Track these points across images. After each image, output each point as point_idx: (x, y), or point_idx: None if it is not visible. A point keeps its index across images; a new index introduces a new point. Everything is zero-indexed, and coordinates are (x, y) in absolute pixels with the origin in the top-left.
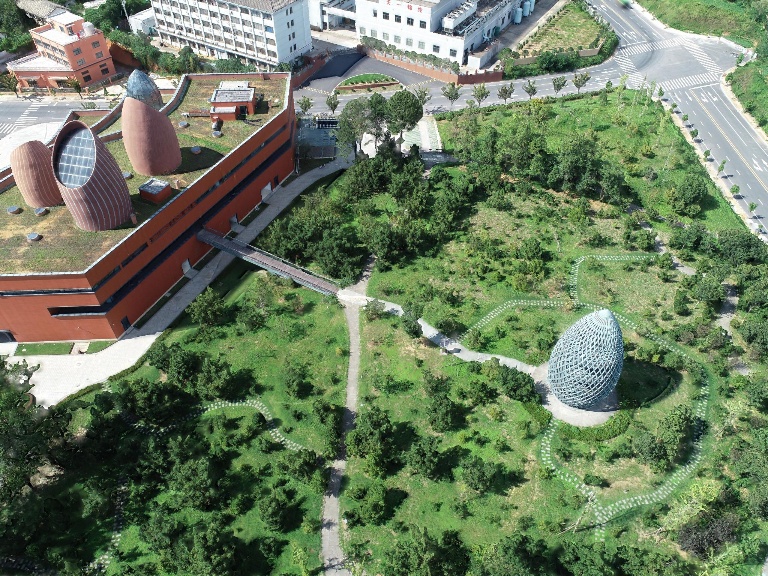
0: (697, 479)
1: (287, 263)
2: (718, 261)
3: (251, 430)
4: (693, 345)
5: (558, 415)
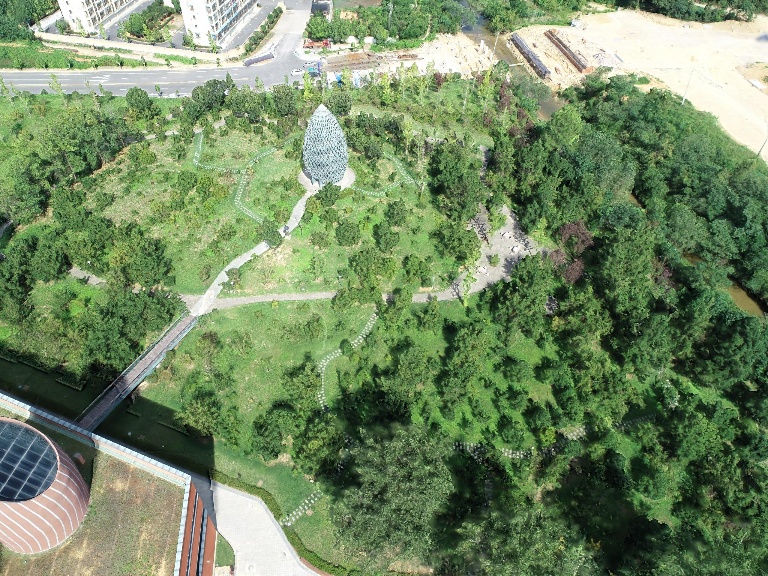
0: None
1: (140, 359)
2: (215, 109)
3: None
4: (288, 133)
5: (347, 186)
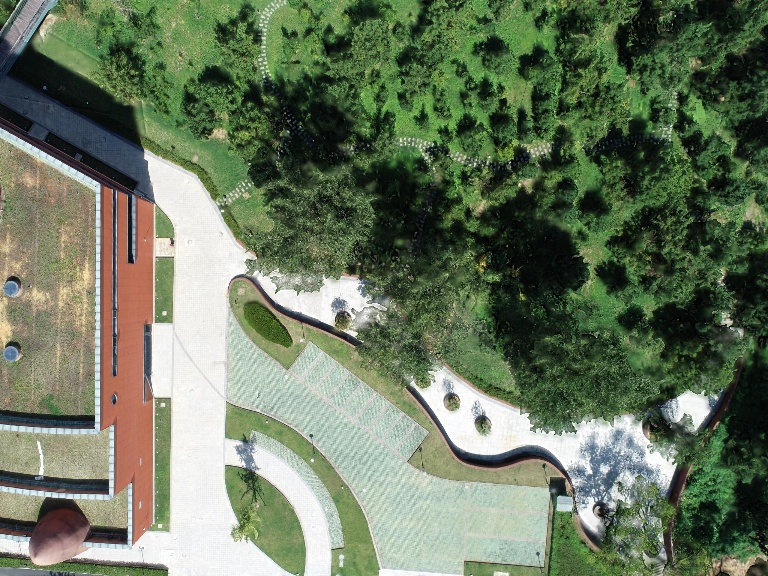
0: None
1: None
2: None
3: (306, 8)
4: None
5: None
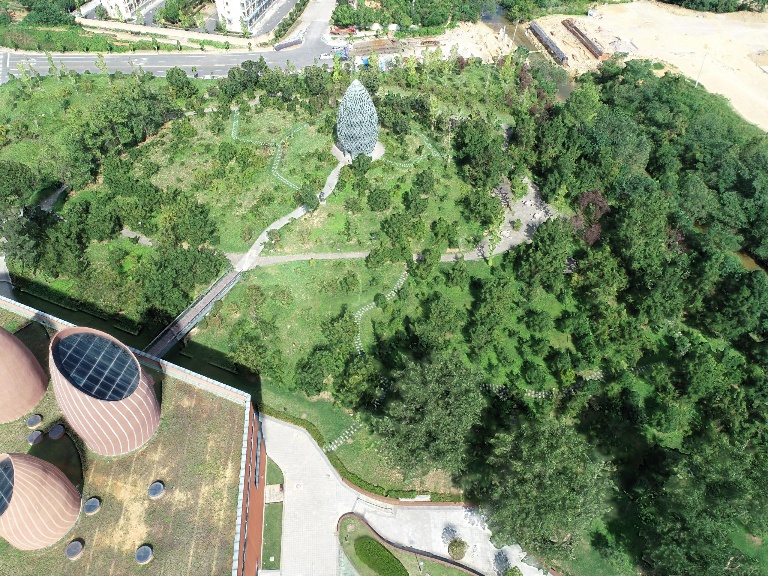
0: (410, 125)
1: None
2: (250, 89)
3: None
4: (319, 111)
5: (378, 158)
